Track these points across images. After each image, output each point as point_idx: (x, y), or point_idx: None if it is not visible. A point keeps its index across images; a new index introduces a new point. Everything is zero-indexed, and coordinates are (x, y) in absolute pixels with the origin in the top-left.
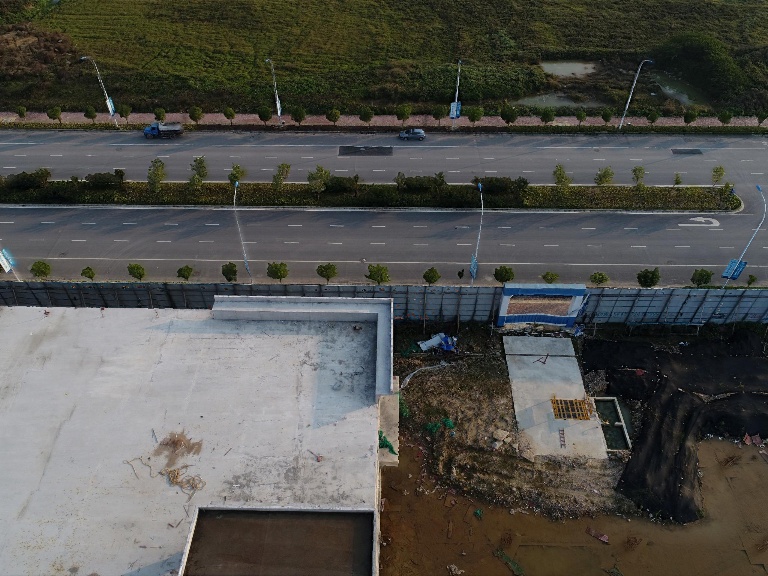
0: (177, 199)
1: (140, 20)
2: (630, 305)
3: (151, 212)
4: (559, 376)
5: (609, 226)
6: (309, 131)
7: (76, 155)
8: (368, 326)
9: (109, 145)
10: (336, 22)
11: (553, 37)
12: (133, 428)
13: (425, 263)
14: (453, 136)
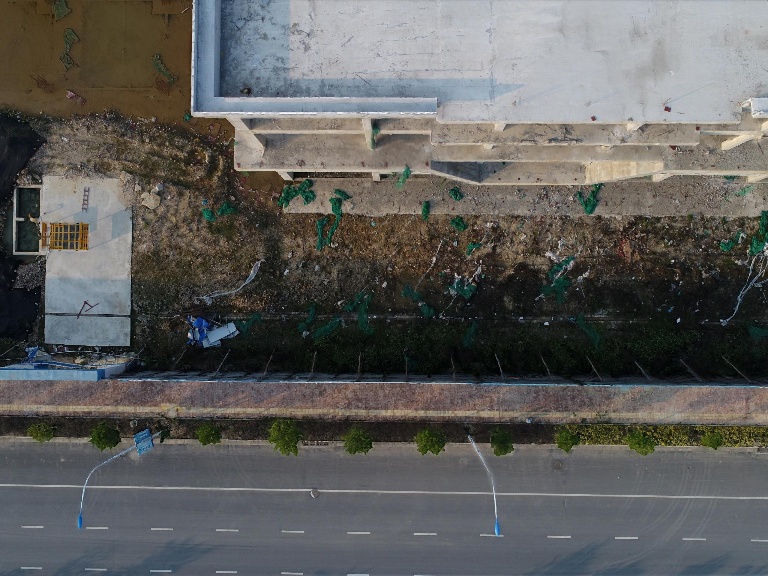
0: None
1: None
2: None
3: None
4: (72, 283)
5: None
6: None
7: None
8: (233, 96)
9: None
10: None
11: None
12: None
13: (223, 488)
14: None
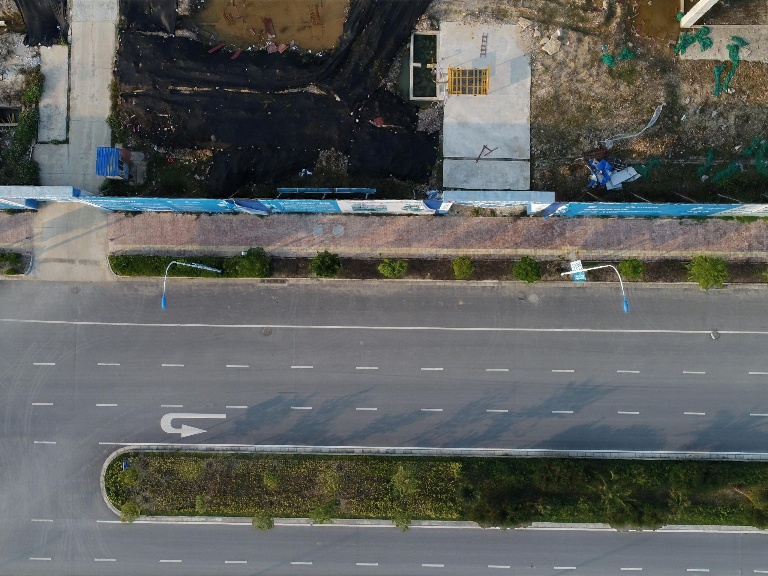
0: None
1: None
2: (370, 207)
3: None
4: (471, 128)
5: (334, 414)
6: None
7: None
8: None
9: None
10: None
11: None
12: None
13: (624, 330)
14: None
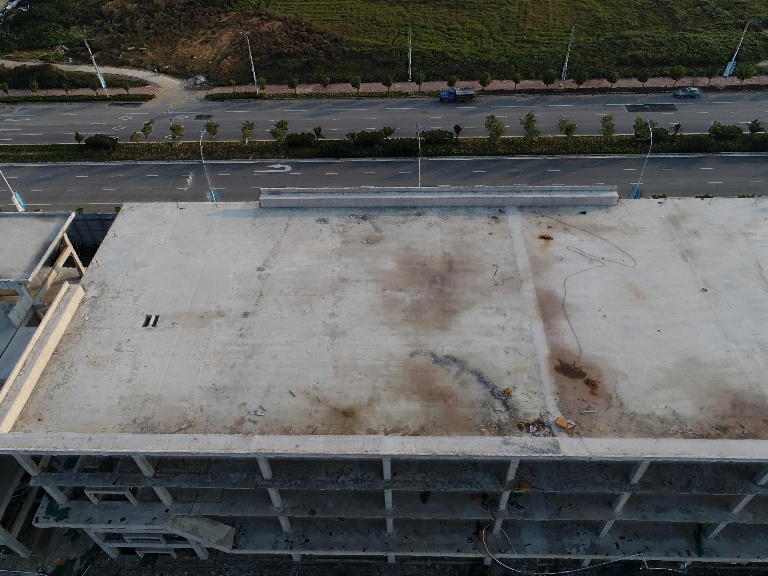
0: (511, 150)
1: (360, 4)
2: None
3: (492, 162)
4: None
5: None
6: (588, 93)
7: (389, 118)
8: None
9: (412, 109)
10: (545, 1)
11: (764, 7)
12: None
13: None
14: (724, 94)
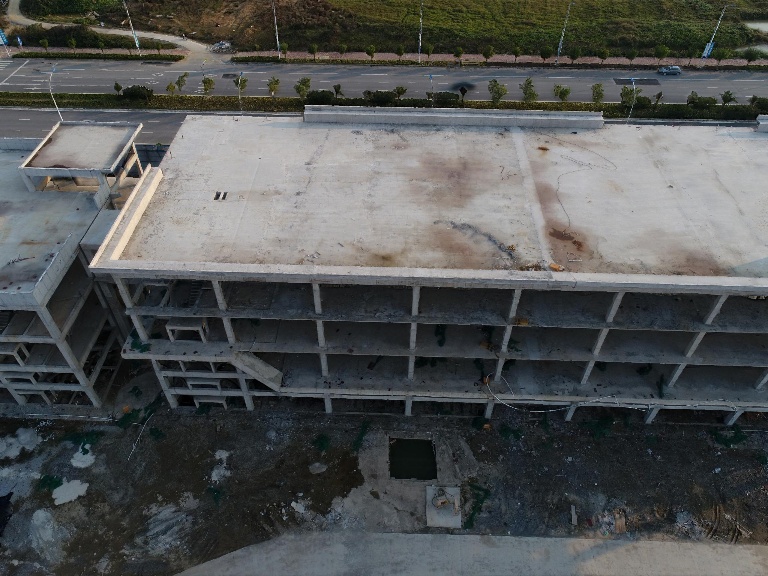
0: None
1: None
2: None
3: None
4: None
5: None
6: (581, 68)
7: (400, 82)
8: None
9: (421, 76)
10: None
11: (742, 2)
12: (765, 179)
13: None
14: (702, 72)
